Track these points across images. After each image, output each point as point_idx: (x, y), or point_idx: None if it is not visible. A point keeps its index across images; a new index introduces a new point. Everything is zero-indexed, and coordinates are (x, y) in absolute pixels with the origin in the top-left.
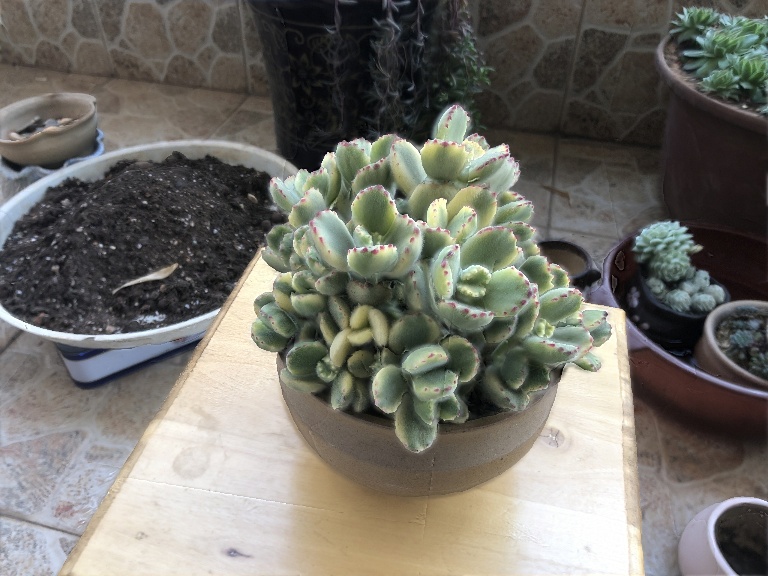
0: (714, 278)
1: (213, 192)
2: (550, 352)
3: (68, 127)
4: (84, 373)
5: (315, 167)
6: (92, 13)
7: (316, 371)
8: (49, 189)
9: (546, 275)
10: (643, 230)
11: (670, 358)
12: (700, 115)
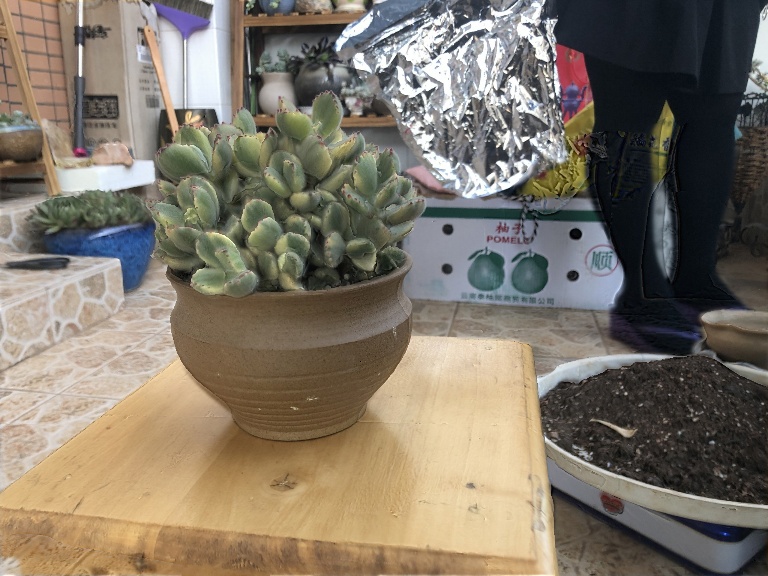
0: None
1: None
2: None
3: (754, 331)
4: None
5: None
6: None
7: None
8: None
9: None
10: None
11: None
12: None
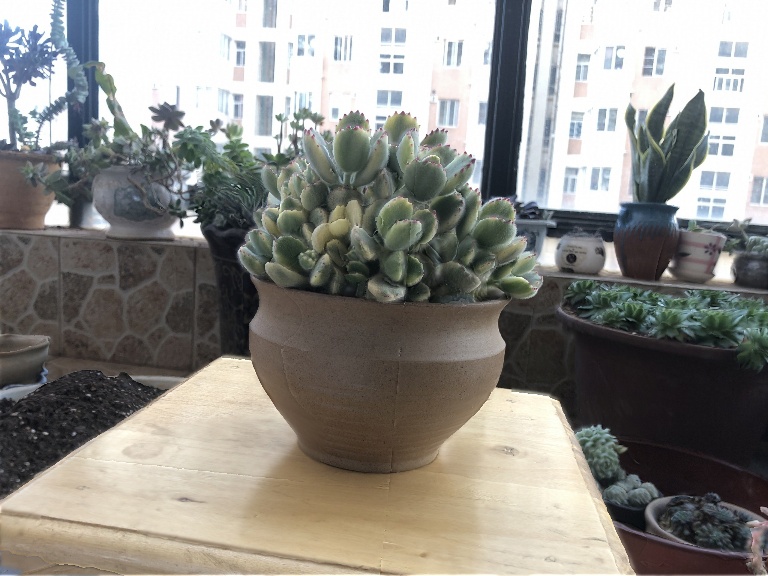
0: None
1: None
2: (493, 222)
3: (19, 350)
4: None
5: None
6: (56, 297)
7: (298, 257)
8: None
9: None
10: None
11: (617, 525)
12: (600, 344)
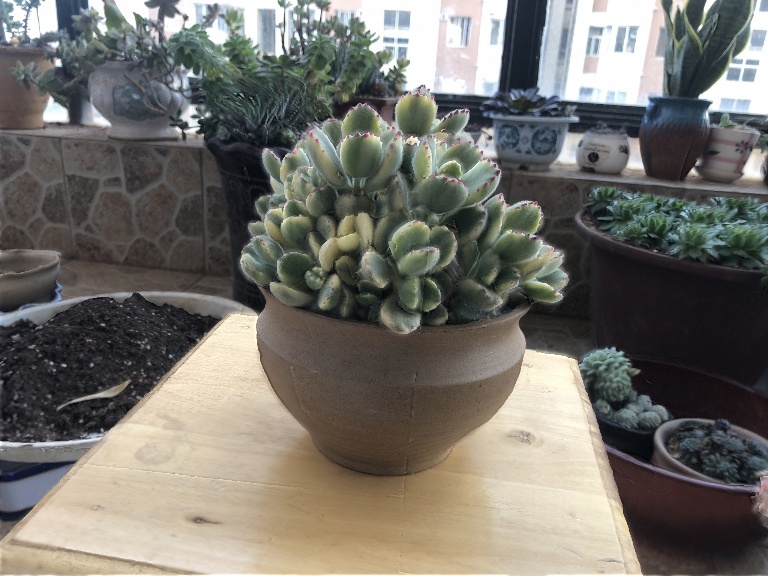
0: (655, 402)
1: (171, 325)
2: (518, 239)
3: (31, 271)
4: (9, 500)
5: None
6: (63, 200)
7: (305, 276)
8: (0, 328)
9: None
10: (584, 359)
11: (626, 457)
12: (619, 261)
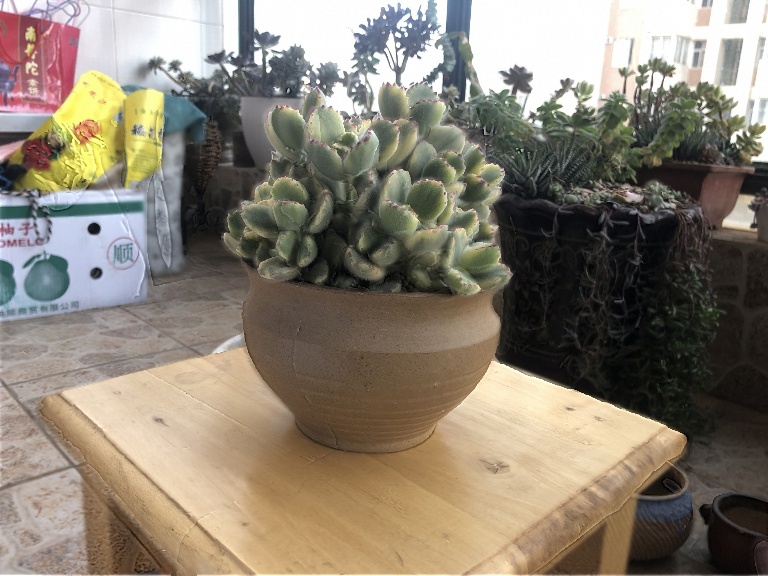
0: None
1: None
2: (385, 206)
3: None
4: None
5: (520, 368)
6: None
7: None
8: None
9: (448, 201)
10: None
11: None
12: None
